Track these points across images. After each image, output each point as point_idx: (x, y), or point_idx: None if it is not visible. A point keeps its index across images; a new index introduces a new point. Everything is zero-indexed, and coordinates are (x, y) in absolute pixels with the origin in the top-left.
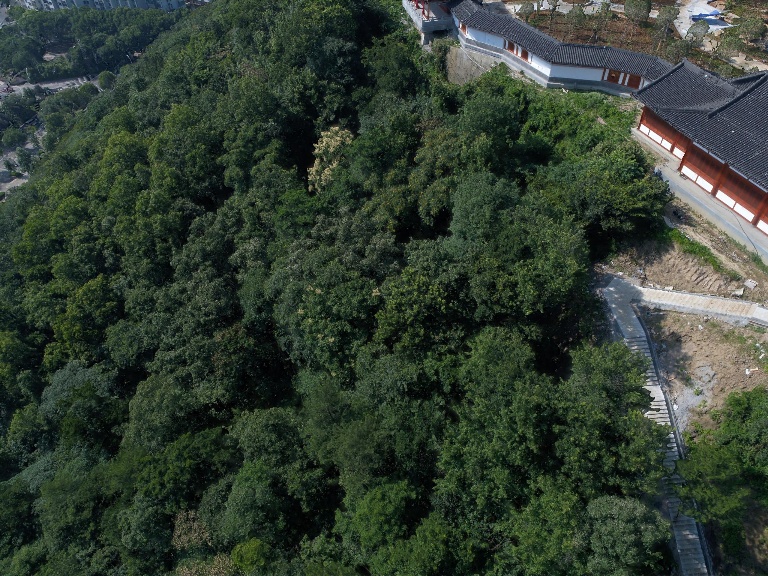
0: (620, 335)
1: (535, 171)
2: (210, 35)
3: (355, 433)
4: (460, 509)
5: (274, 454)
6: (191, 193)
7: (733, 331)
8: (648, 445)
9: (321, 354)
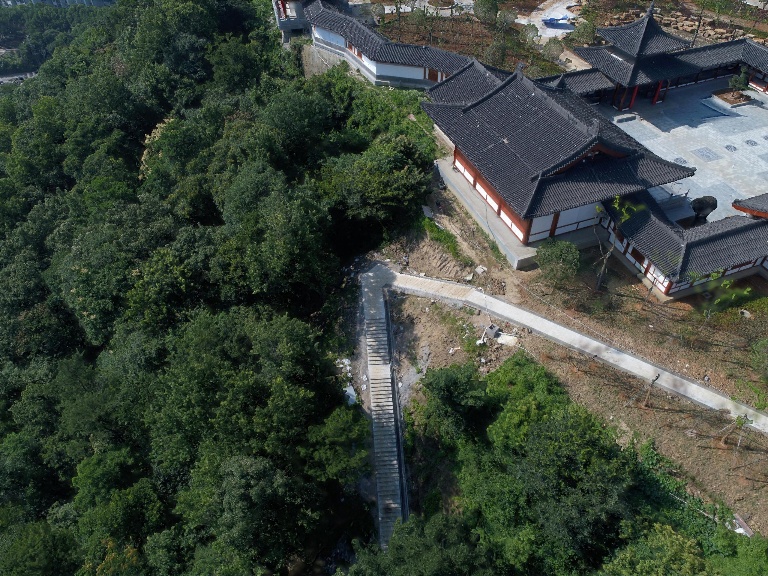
0: (363, 317)
1: None
2: (102, 31)
3: (85, 403)
4: (186, 477)
5: (38, 425)
6: (42, 181)
7: (449, 313)
8: (279, 409)
9: (90, 331)
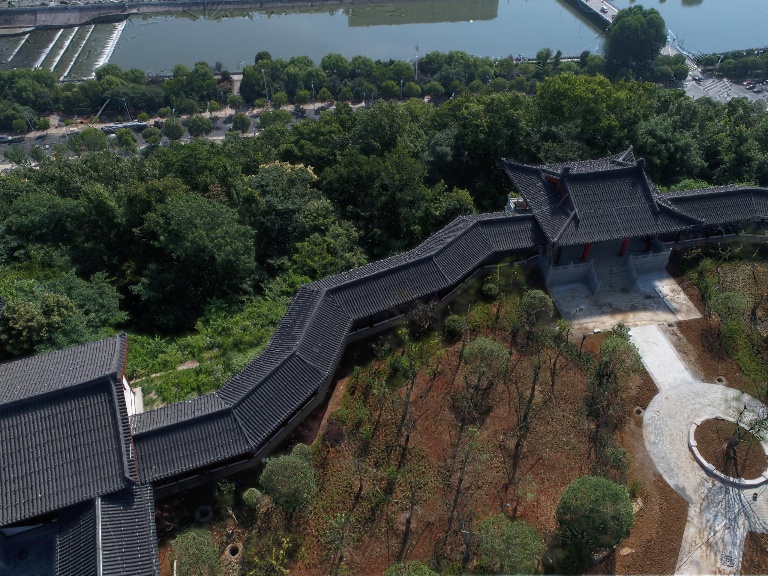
0: None
1: (164, 314)
2: None
3: None
4: None
5: None
6: None
7: None
8: None
9: None
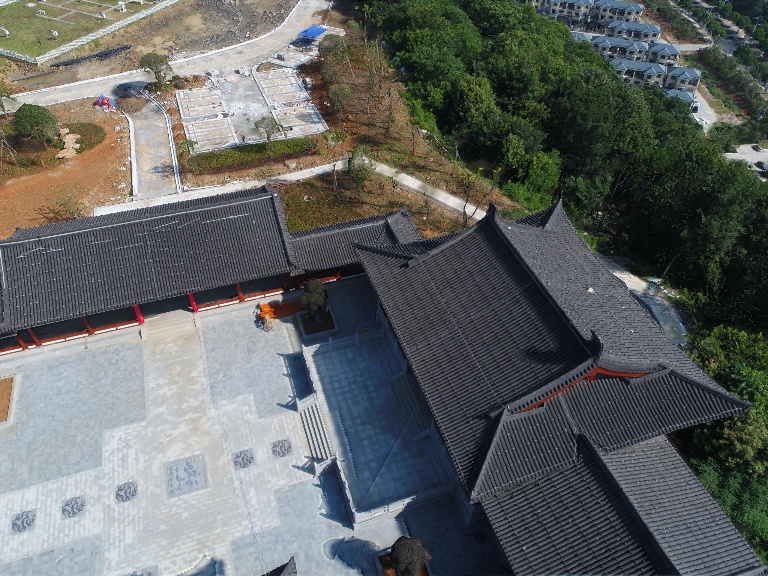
0: None
1: None
2: None
3: None
4: None
5: None
6: None
7: None
8: None
9: None
